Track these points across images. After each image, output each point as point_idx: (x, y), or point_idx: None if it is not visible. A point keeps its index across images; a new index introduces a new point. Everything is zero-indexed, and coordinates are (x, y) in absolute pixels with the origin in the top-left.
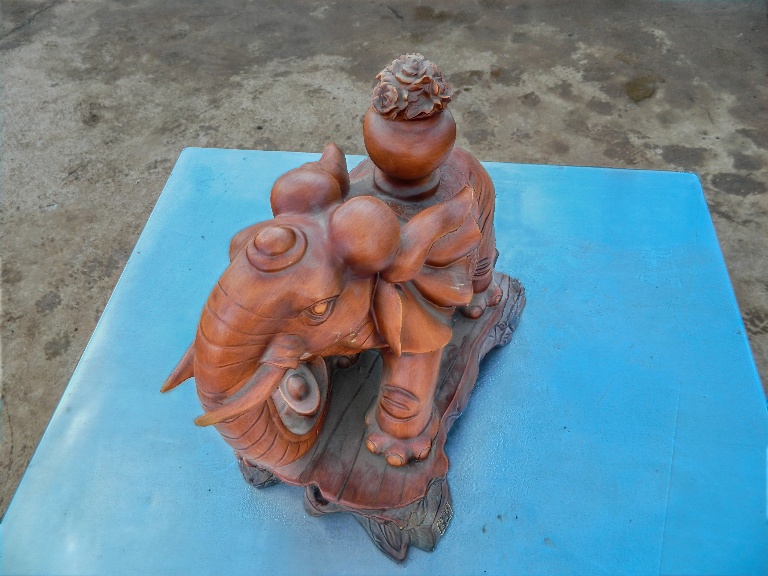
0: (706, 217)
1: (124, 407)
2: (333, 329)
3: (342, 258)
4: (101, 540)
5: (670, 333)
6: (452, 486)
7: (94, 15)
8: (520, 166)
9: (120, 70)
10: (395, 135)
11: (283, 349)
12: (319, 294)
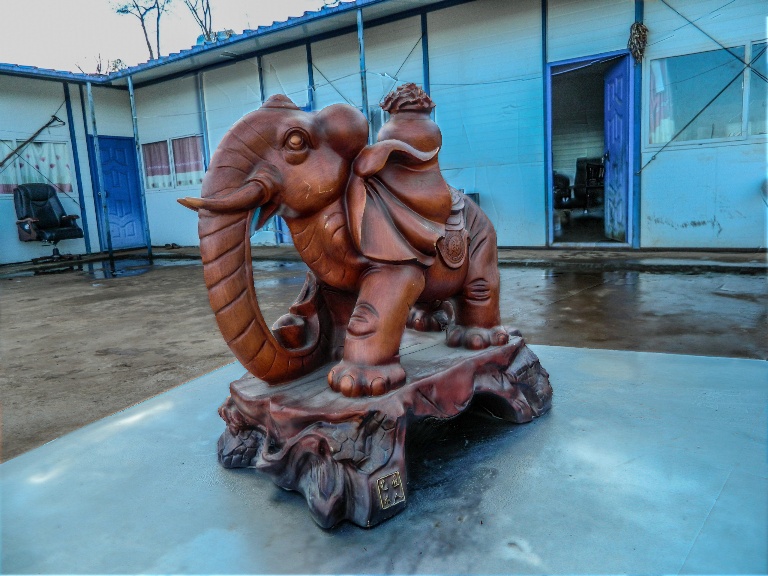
0: None
1: (157, 419)
2: (305, 177)
3: (320, 122)
4: (71, 476)
5: (727, 436)
6: (418, 493)
7: None
8: None
9: None
10: (392, 122)
11: (264, 171)
12: (294, 123)
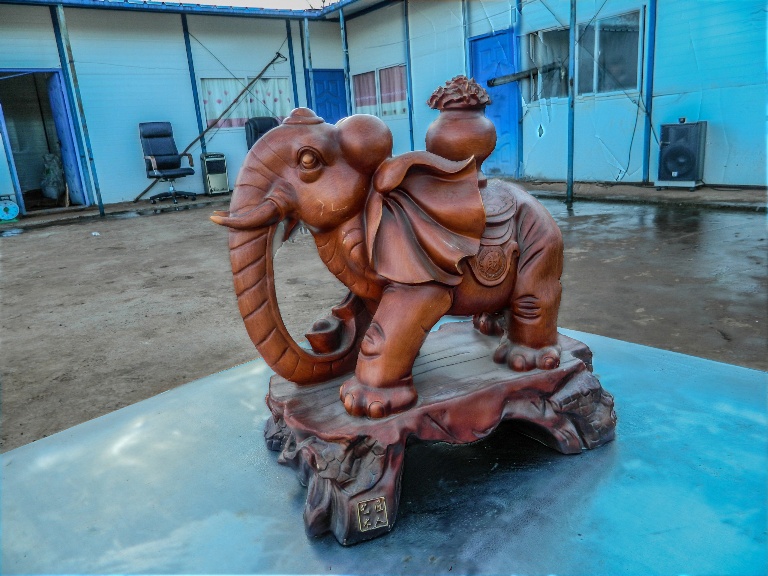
0: None
1: (246, 384)
2: (318, 195)
3: (336, 137)
4: (159, 431)
5: None
6: (412, 517)
7: None
8: (710, 361)
9: None
10: (437, 122)
11: (279, 189)
12: (306, 142)
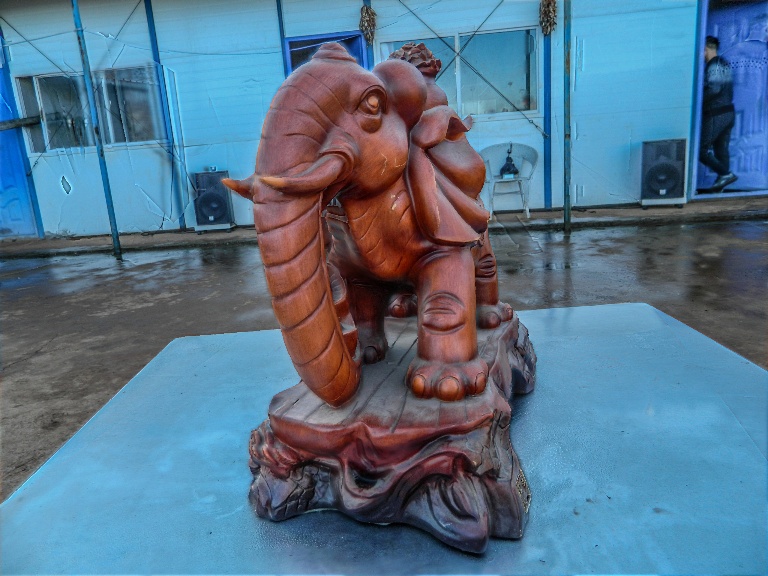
0: (668, 317)
1: (97, 486)
2: (381, 149)
3: (385, 81)
4: None
5: (685, 369)
6: None
7: (70, 360)
8: None
9: (89, 390)
10: None
11: (341, 140)
12: (373, 80)
